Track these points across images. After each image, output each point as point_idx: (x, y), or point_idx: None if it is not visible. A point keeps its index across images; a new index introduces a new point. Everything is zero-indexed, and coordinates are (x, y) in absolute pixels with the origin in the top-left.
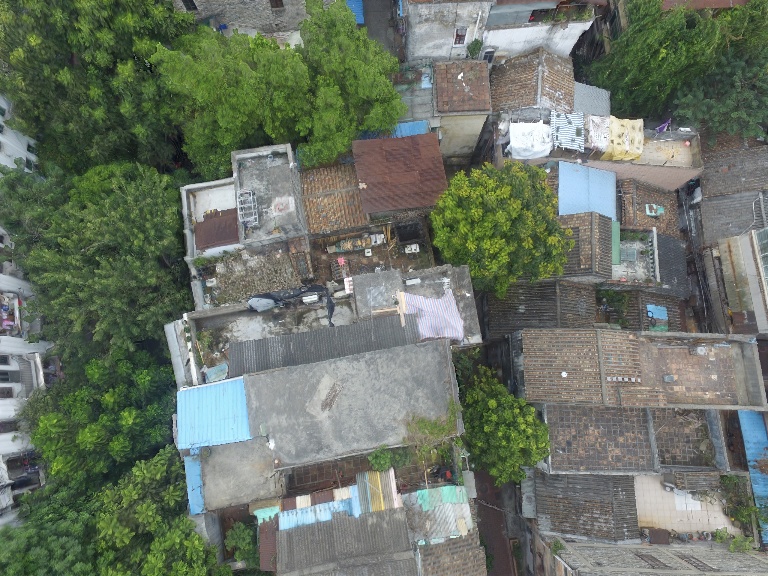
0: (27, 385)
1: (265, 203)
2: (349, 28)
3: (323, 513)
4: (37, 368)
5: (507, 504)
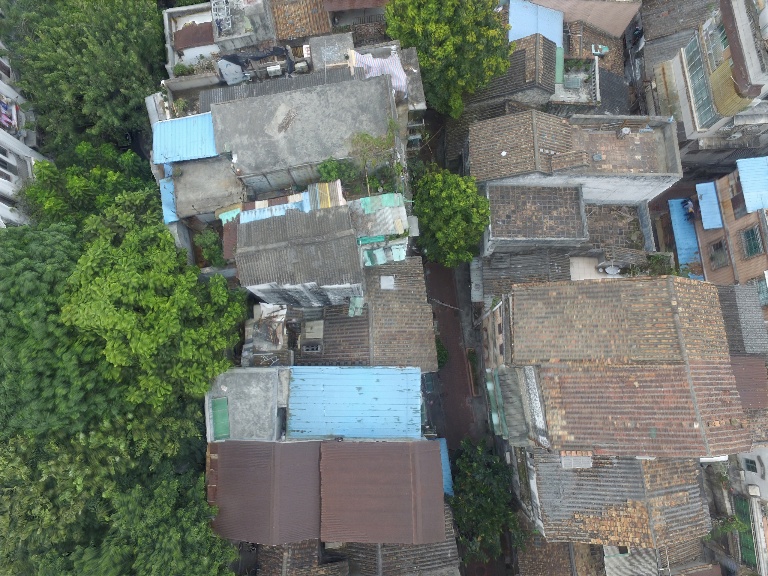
0: (24, 177)
1: (238, 14)
2: None
3: (278, 211)
4: None
5: (464, 320)
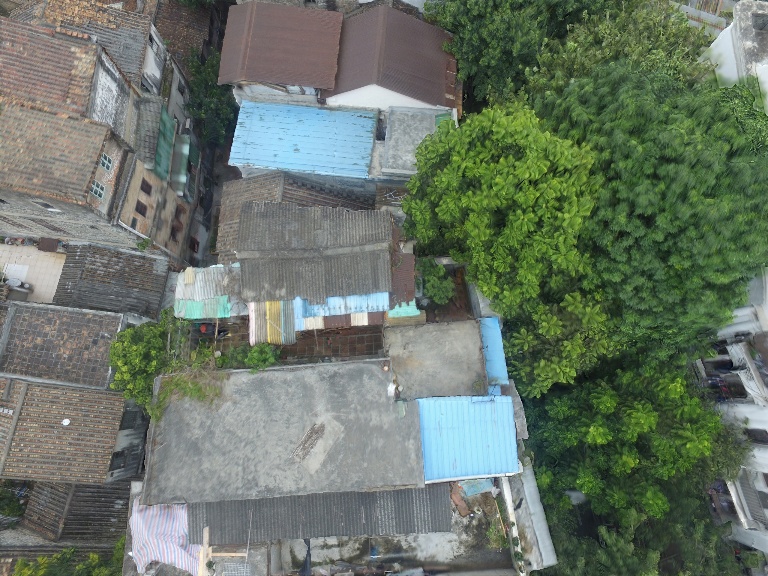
0: (748, 486)
1: None
2: None
3: (337, 305)
4: (741, 507)
5: None
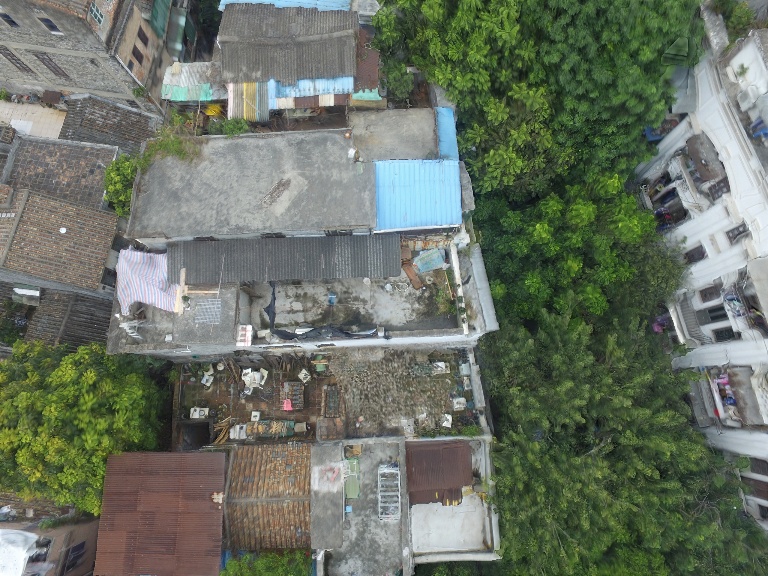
0: (687, 306)
1: (370, 501)
2: None
3: (307, 88)
4: (681, 329)
5: None
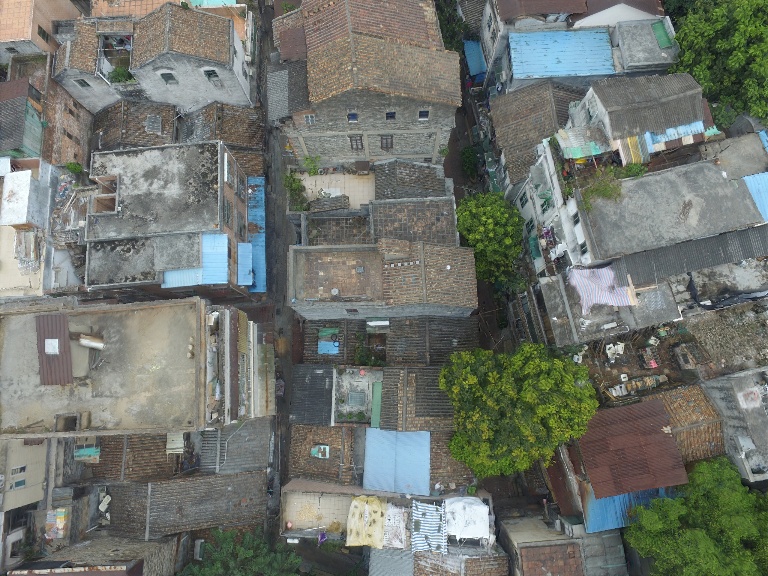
0: None
1: None
2: None
3: (672, 133)
4: None
5: None
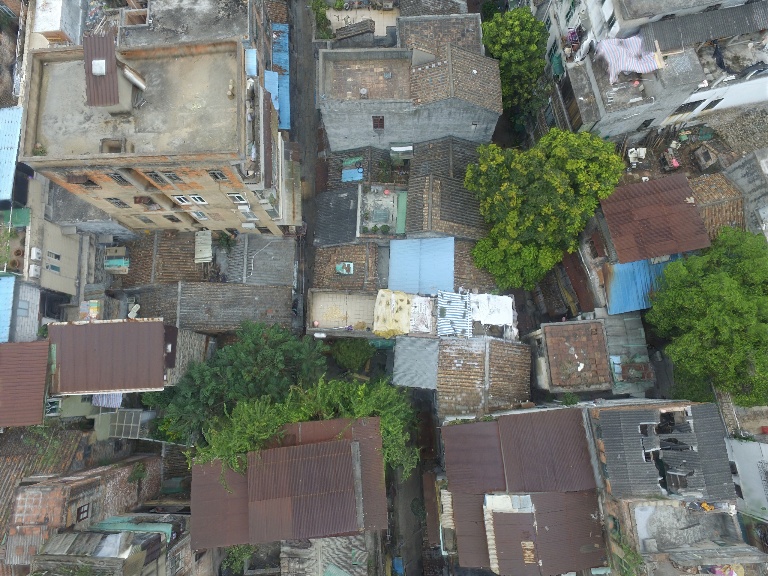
0: None
1: None
2: (766, 347)
3: None
4: None
5: None
